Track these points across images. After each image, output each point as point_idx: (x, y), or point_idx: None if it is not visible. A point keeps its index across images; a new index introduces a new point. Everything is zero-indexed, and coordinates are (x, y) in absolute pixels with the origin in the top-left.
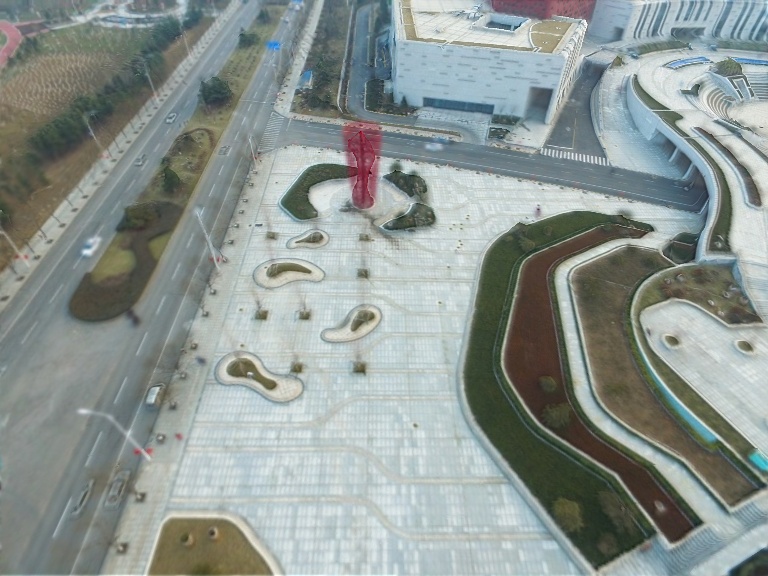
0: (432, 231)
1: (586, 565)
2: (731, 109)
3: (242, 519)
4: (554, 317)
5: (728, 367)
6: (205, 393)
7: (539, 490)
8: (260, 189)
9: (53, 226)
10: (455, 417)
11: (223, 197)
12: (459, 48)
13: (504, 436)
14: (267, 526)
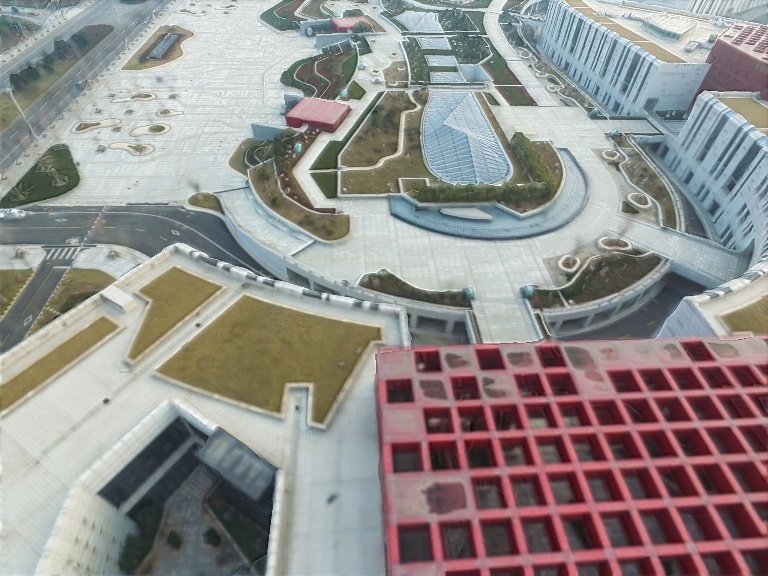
0: None
1: None
2: None
3: (184, 27)
4: (299, 5)
5: None
6: (172, 14)
7: None
8: None
9: None
10: None
11: None
12: None
13: (268, 19)
14: (191, 28)
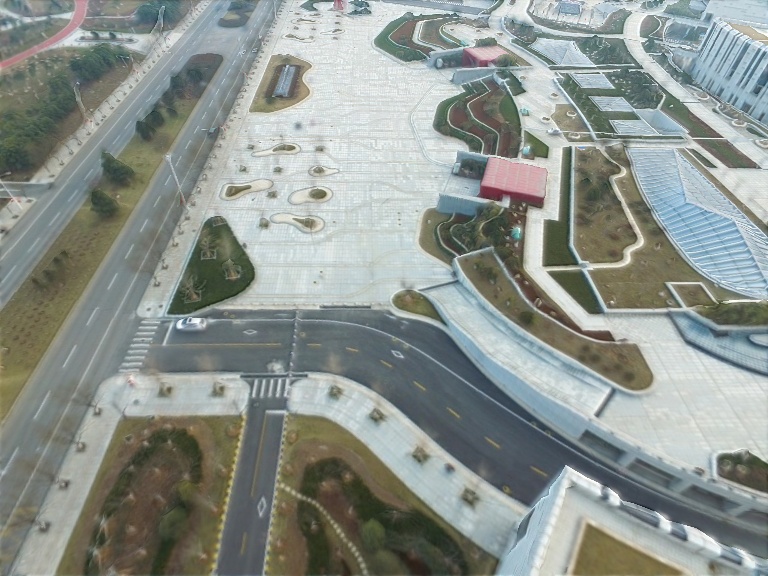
0: (369, 16)
1: (403, 62)
2: None
3: None
4: None
5: None
6: None
7: (393, 53)
8: (290, 4)
9: (199, 8)
10: (369, 47)
11: None
12: None
13: None
14: (305, 57)
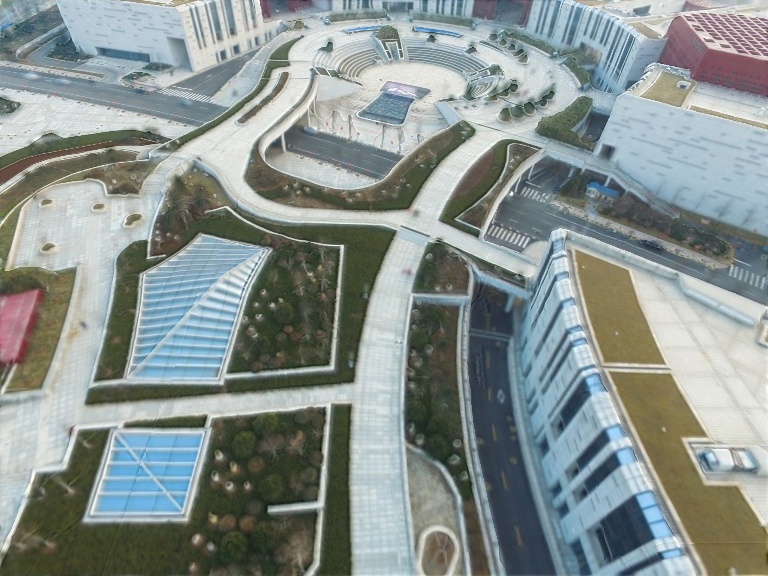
0: None
1: None
2: (374, 66)
3: None
4: None
5: (69, 218)
6: None
7: None
8: None
9: None
10: None
11: None
12: (99, 1)
13: None
14: None
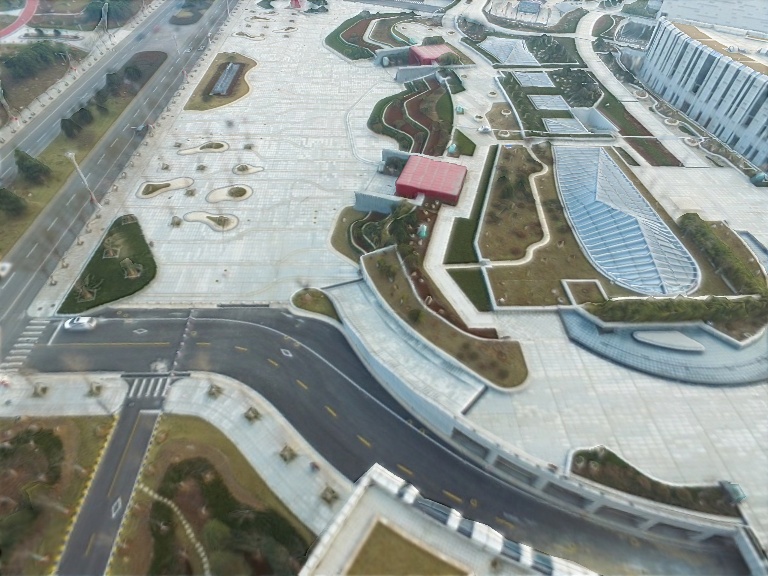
0: (326, 15)
1: (350, 61)
2: None
3: (243, 54)
4: None
5: None
6: None
7: None
8: (247, 1)
9: (153, 6)
10: (320, 45)
11: (229, 3)
12: None
13: (334, 45)
14: (252, 55)
